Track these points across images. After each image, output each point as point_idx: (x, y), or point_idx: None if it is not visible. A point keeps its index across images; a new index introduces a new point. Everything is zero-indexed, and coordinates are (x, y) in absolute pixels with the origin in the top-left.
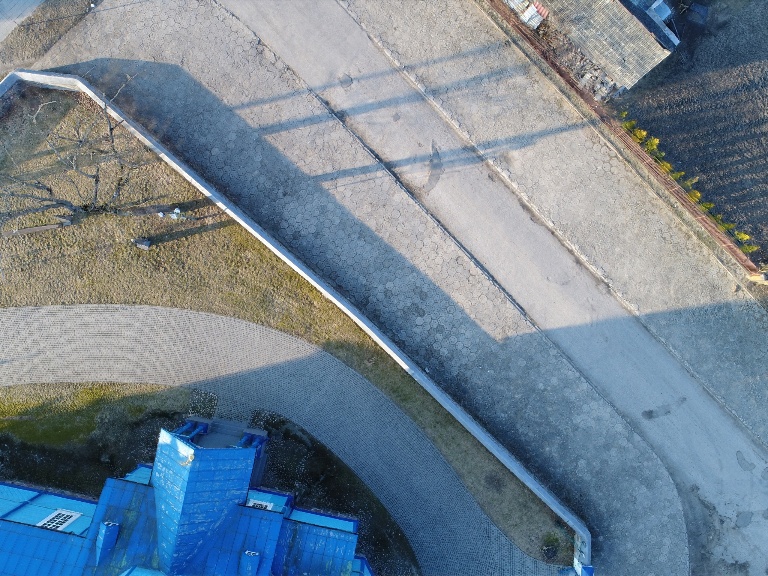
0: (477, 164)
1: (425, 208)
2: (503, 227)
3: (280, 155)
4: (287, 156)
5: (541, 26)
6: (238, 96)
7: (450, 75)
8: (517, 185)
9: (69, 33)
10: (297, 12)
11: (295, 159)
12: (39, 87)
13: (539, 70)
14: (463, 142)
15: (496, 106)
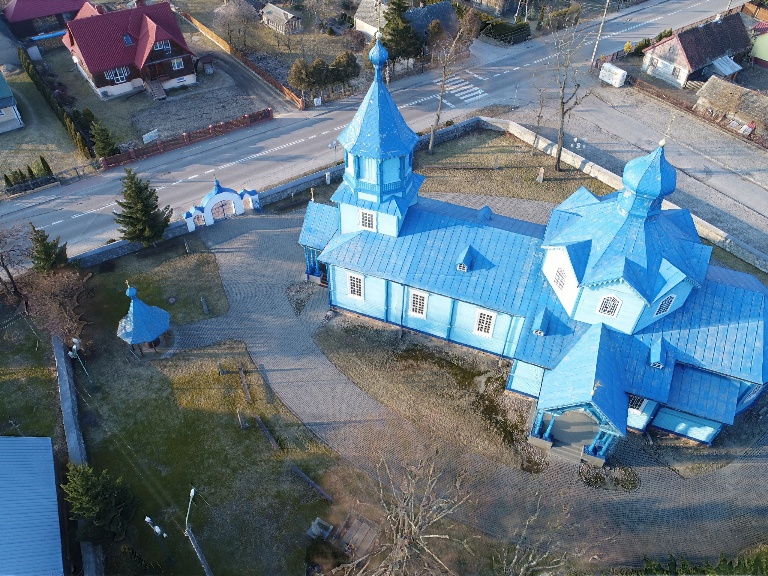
0: (733, 174)
1: (707, 185)
2: (759, 196)
3: (616, 159)
4: (620, 160)
5: (751, 134)
6: (590, 140)
7: (705, 146)
8: (761, 183)
9: (501, 115)
10: (617, 121)
11: (625, 161)
12: (483, 128)
13: (756, 147)
14: (721, 167)
15: (736, 157)
